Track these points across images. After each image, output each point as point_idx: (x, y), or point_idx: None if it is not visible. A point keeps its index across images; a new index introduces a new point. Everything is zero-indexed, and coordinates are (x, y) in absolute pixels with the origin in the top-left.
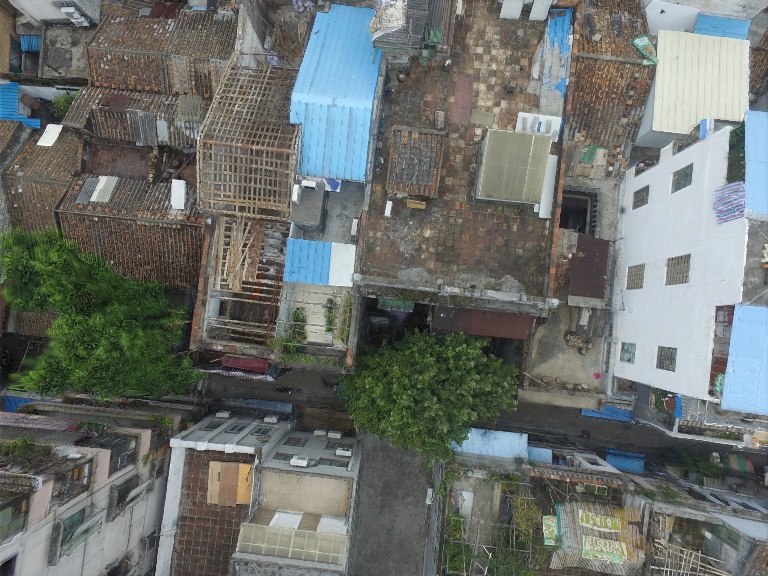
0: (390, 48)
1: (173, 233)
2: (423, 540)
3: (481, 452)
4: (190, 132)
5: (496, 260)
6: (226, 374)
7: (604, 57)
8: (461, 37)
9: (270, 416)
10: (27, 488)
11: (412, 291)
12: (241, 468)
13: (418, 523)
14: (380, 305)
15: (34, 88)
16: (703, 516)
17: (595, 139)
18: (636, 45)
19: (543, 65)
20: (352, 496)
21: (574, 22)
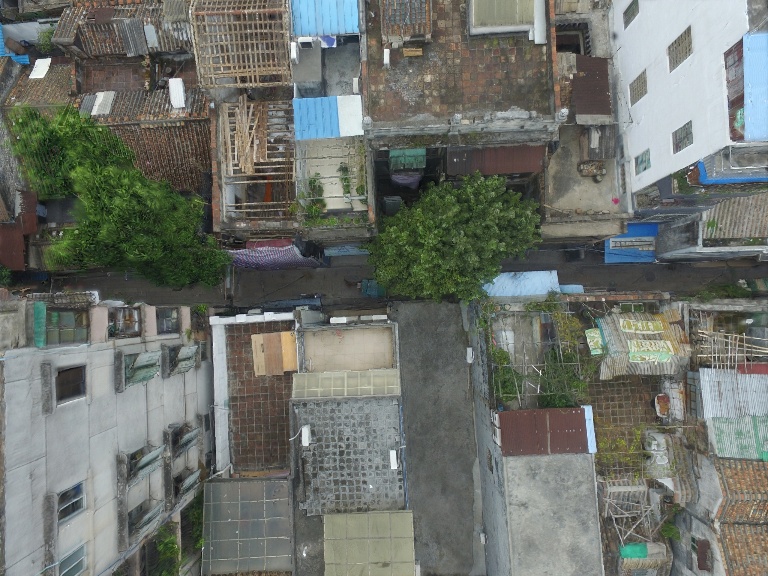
0: None
1: (178, 132)
2: (470, 405)
3: (514, 294)
4: (178, 33)
5: (500, 93)
6: (253, 254)
7: None
8: None
9: (301, 306)
10: (85, 303)
11: (422, 137)
12: (283, 336)
13: (462, 389)
14: (392, 165)
15: (17, 26)
16: (741, 306)
17: None
18: None
19: None
20: (396, 342)
21: None
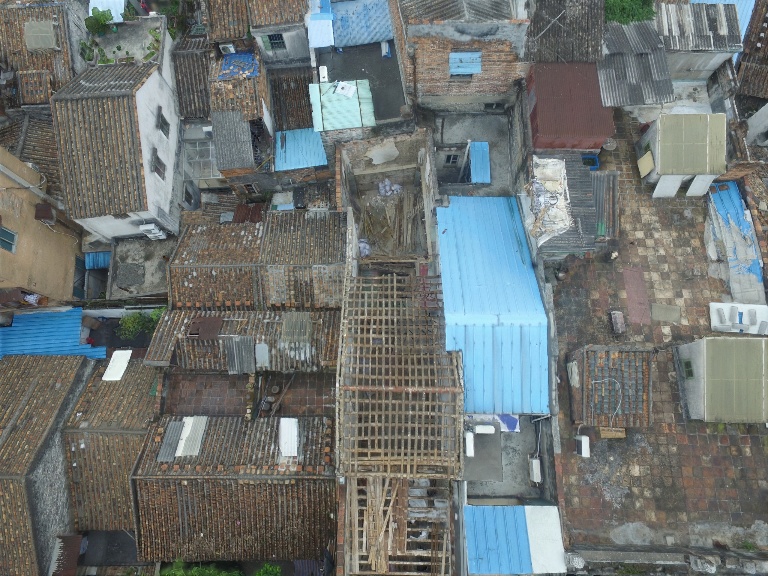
0: (560, 252)
1: (285, 490)
2: None
3: None
4: (295, 353)
5: (736, 500)
6: None
7: None
8: None
9: None
10: None
11: None
12: None
13: None
14: None
15: (99, 311)
16: None
17: None
18: None
19: (722, 246)
20: None
21: (745, 196)
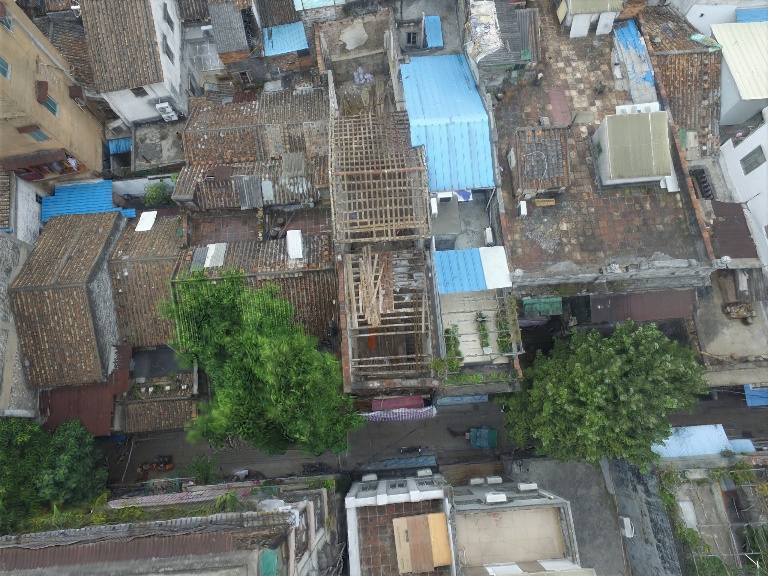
0: (494, 66)
1: (295, 283)
2: None
3: (680, 454)
4: (294, 187)
5: (640, 240)
6: (384, 416)
7: (672, 52)
8: (541, 57)
9: (422, 469)
10: (282, 526)
11: (566, 285)
12: (431, 520)
13: (618, 570)
14: (527, 313)
15: (126, 183)
16: None
17: (682, 124)
18: (695, 40)
19: (624, 65)
20: (571, 525)
21: (640, 27)
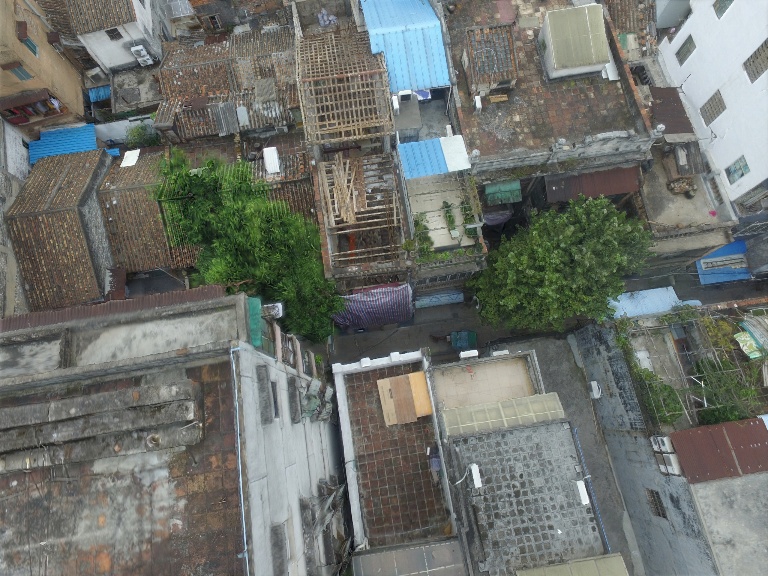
0: None
1: (274, 194)
2: (603, 449)
3: (636, 314)
4: (268, 112)
5: (587, 124)
6: (364, 299)
7: None
8: None
9: None
10: (268, 317)
11: (522, 168)
12: (411, 378)
13: (590, 432)
14: (490, 202)
15: (108, 126)
16: None
17: (622, 28)
18: None
19: None
20: (537, 369)
21: None
